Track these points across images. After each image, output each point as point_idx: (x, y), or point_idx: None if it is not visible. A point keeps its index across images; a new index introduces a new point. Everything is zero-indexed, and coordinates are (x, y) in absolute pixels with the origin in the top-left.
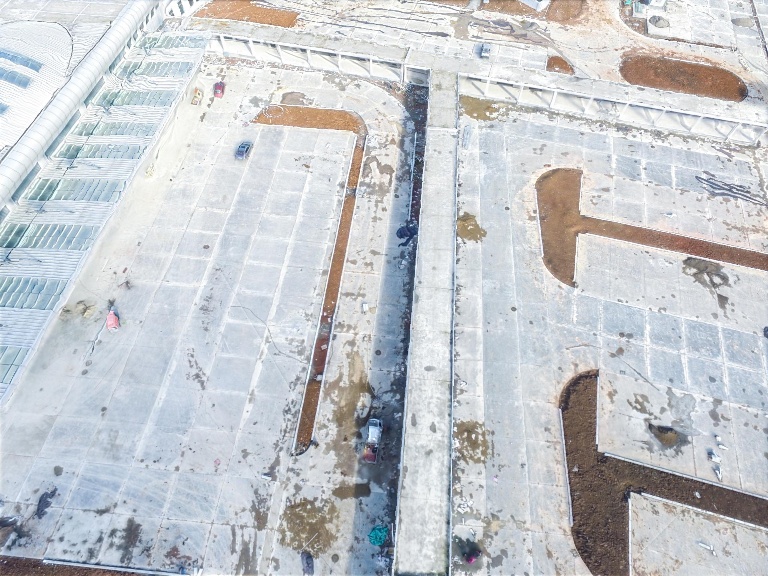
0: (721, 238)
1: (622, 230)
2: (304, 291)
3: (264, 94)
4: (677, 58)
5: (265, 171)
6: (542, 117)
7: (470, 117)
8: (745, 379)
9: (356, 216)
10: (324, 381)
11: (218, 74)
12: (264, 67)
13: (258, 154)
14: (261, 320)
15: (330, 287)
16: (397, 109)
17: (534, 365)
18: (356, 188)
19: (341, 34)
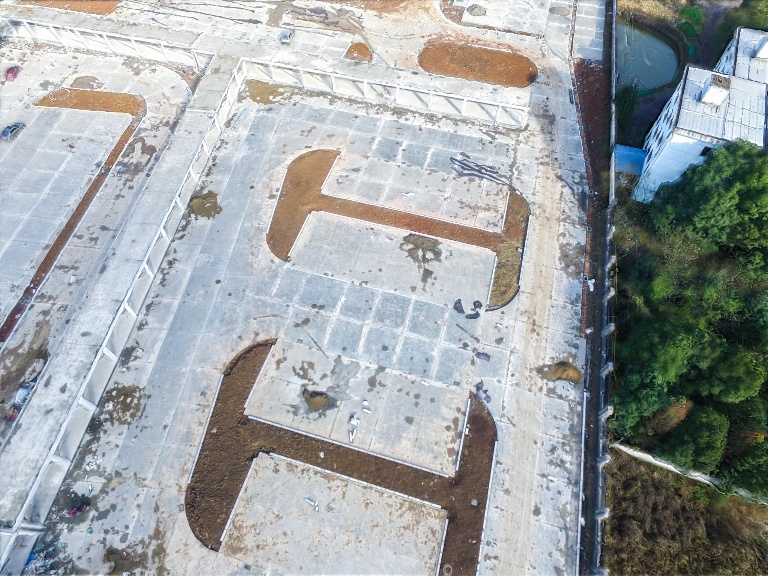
0: (449, 216)
1: (354, 208)
2: (20, 264)
3: (57, 78)
4: (480, 45)
5: (28, 151)
6: (323, 101)
7: (252, 101)
8: (417, 348)
9: (99, 194)
10: (4, 348)
11: (20, 59)
12: (67, 52)
13: (28, 135)
14: None
15: (46, 260)
16: (183, 93)
17: (216, 334)
18: (111, 167)
19: (154, 21)
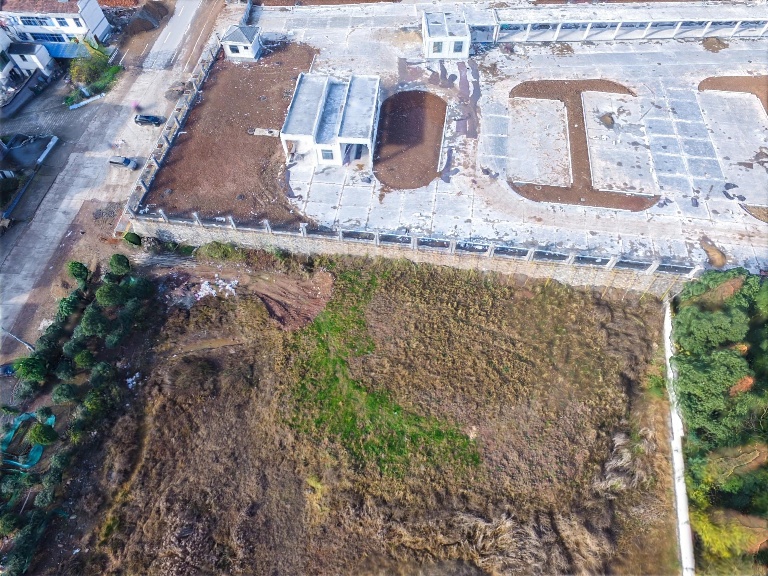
0: None
1: None
2: None
3: None
4: None
5: None
6: None
7: None
8: (676, 164)
9: (685, 2)
10: (568, 4)
11: None
12: None
13: None
14: None
15: None
16: None
17: (623, 71)
18: (709, 1)
19: None
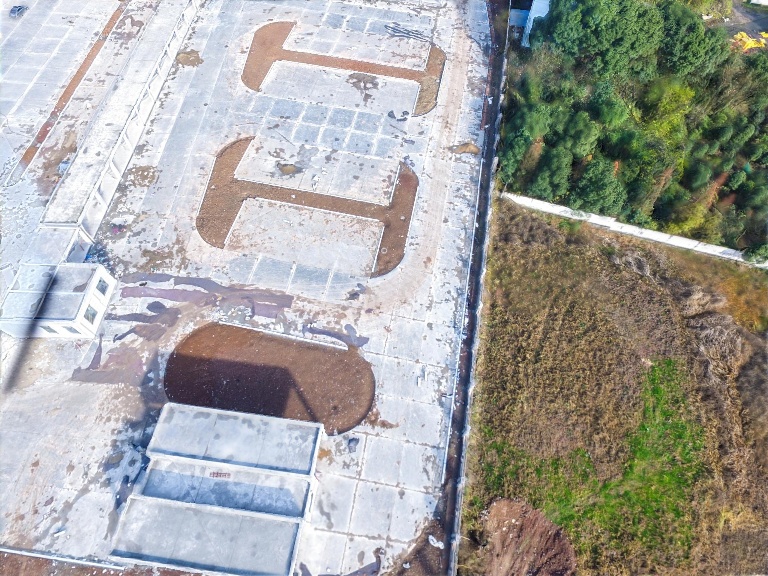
0: (384, 61)
1: (310, 57)
2: (43, 97)
3: None
4: None
5: (34, 25)
6: None
7: None
8: (361, 139)
9: (101, 52)
10: (42, 147)
11: None
12: None
13: (32, 15)
14: (3, 114)
15: (64, 94)
16: None
17: (208, 135)
18: (108, 36)
19: None
